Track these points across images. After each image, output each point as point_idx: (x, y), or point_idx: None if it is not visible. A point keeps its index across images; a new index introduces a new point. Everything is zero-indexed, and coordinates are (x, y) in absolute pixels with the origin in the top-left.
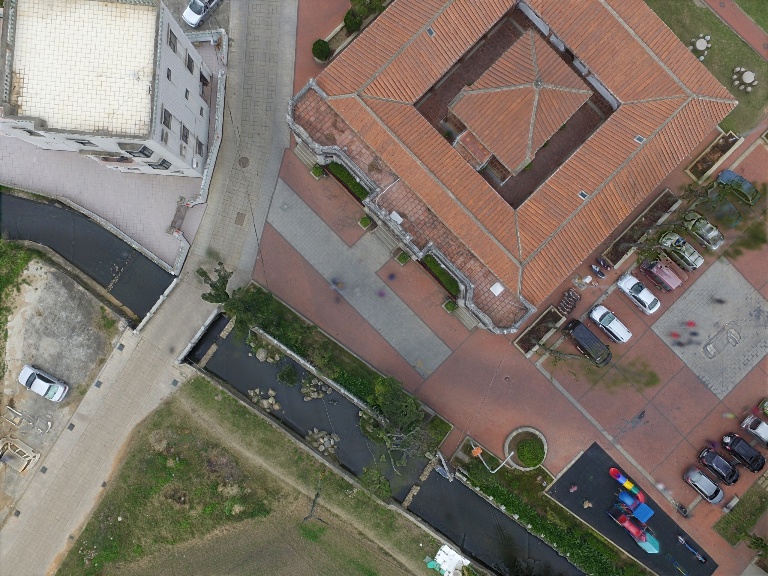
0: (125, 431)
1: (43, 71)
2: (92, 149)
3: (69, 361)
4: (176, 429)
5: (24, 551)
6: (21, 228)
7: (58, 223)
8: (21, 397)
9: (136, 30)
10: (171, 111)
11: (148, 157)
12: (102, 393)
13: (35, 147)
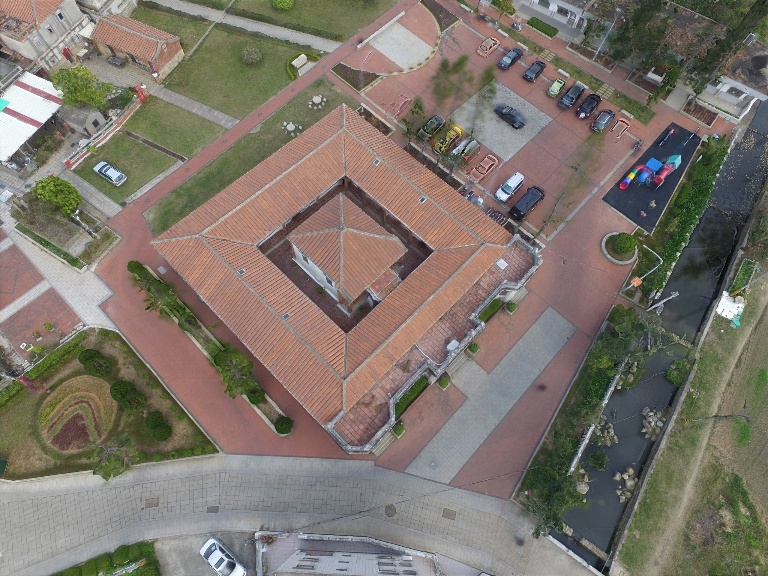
0: None
1: None
2: None
3: None
4: None
5: None
6: None
7: None
8: None
9: None
10: None
11: None
12: None
13: None
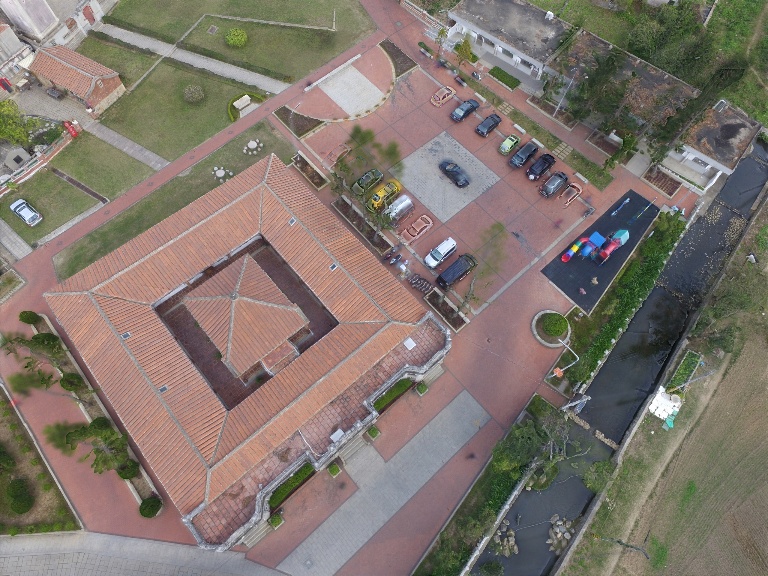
0: None
1: None
2: None
3: None
4: None
5: None
6: None
7: None
8: None
9: None
10: None
11: None
12: None
13: None
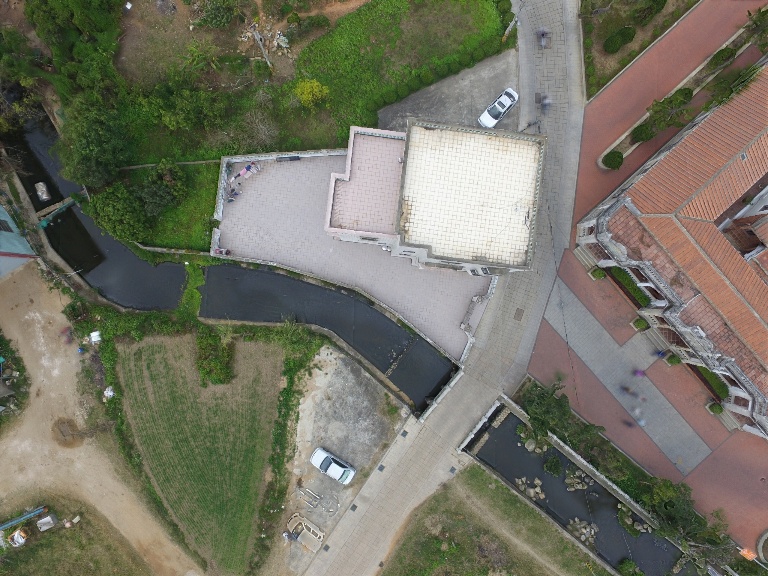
0: (403, 514)
1: (429, 199)
2: None
3: (355, 444)
4: (451, 514)
5: None
6: (307, 312)
7: (342, 309)
8: (309, 477)
9: (516, 163)
10: None
11: None
12: (384, 477)
13: (332, 238)
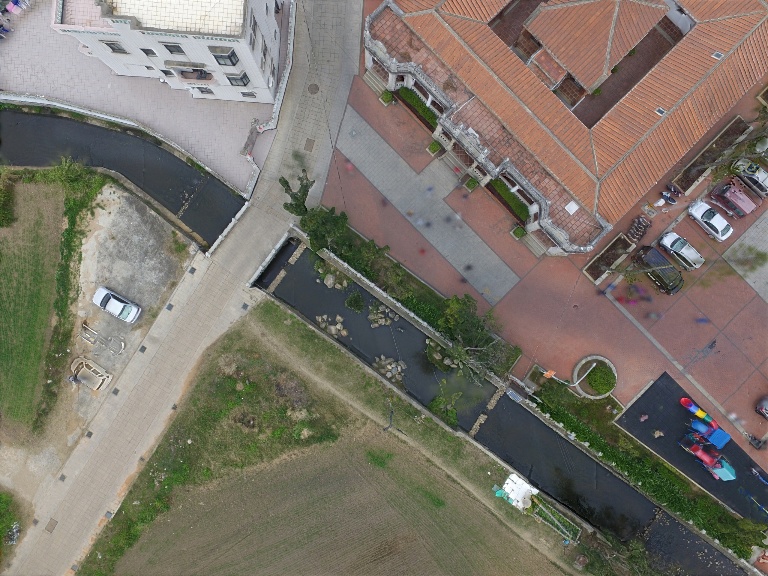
0: (195, 354)
1: None
2: (177, 59)
3: (141, 284)
4: (246, 353)
5: (96, 472)
6: (94, 155)
7: (130, 150)
8: (94, 319)
9: None
10: (256, 19)
11: (233, 65)
12: (173, 316)
13: (110, 73)
